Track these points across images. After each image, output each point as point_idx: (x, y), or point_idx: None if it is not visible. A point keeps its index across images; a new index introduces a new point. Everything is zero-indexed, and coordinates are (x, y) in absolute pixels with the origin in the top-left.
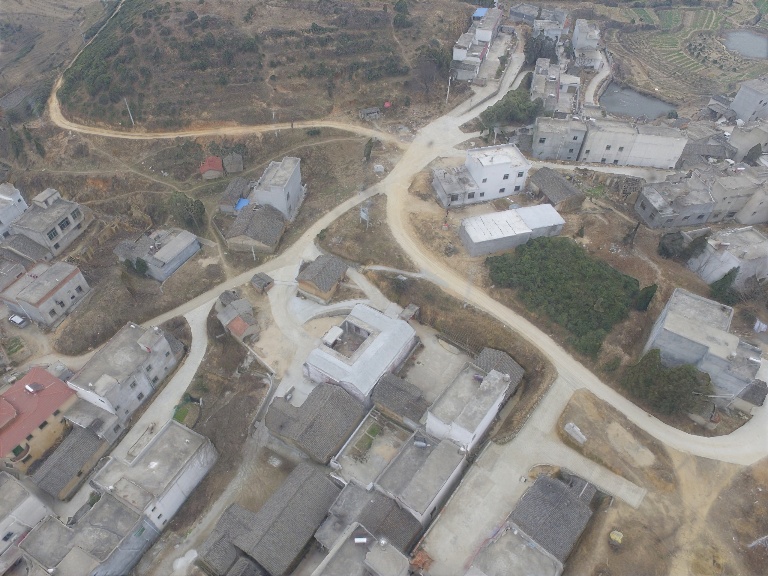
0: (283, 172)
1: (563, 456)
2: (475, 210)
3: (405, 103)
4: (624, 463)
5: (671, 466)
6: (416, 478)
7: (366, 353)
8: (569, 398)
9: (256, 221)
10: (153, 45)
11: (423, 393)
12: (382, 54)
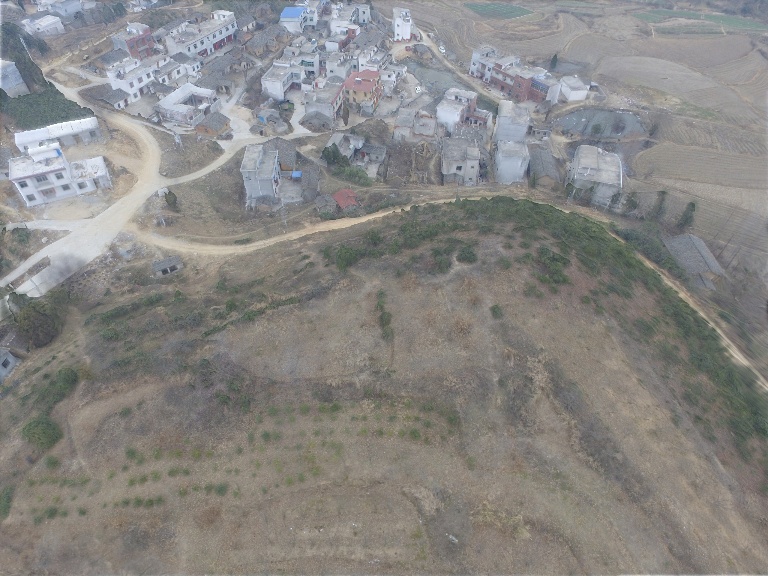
0: (253, 156)
1: (93, 78)
2: (82, 158)
3: (112, 292)
4: (67, 74)
5: (47, 74)
6: (161, 59)
7: (182, 94)
8: (78, 87)
9: (273, 147)
10: (492, 224)
11: (155, 101)
12: (126, 323)
